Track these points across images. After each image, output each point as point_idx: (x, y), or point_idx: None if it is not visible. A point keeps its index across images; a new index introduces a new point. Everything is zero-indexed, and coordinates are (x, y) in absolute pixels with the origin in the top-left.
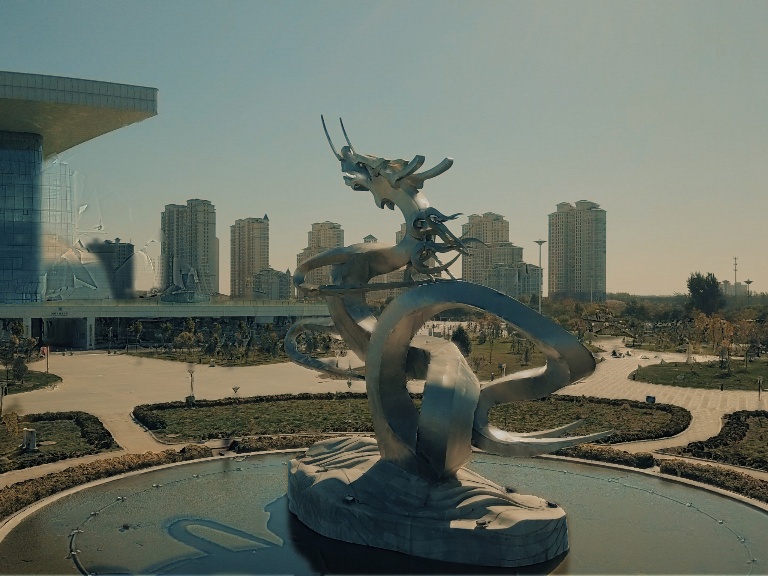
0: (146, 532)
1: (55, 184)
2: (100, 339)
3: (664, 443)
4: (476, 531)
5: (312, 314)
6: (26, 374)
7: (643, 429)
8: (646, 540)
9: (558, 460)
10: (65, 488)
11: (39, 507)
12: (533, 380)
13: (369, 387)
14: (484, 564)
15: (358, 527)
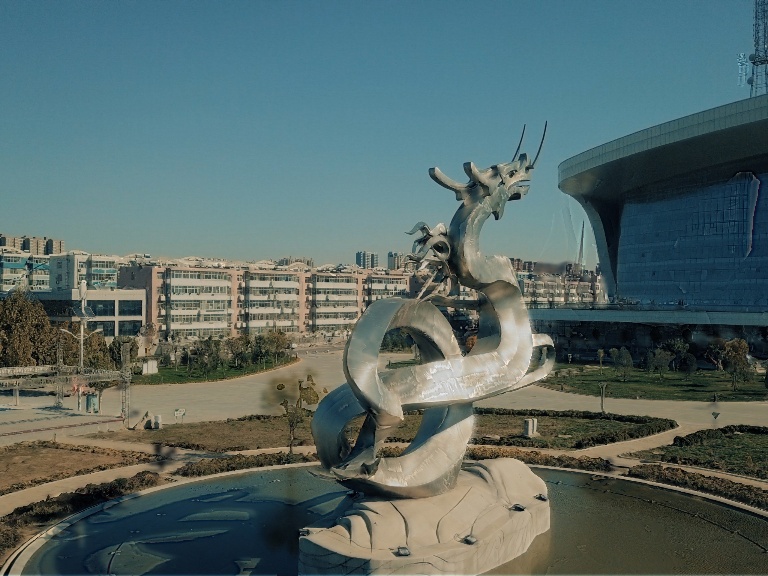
0: None
1: (735, 194)
2: None
3: None
4: None
5: None
6: None
7: None
8: None
9: None
10: None
11: None
12: None
13: None
14: None
15: None
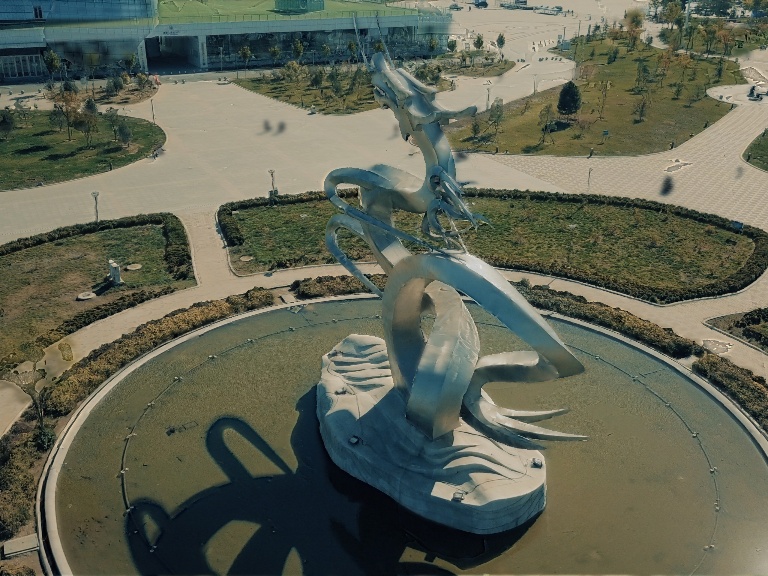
0: (188, 437)
1: None
2: (213, 58)
3: (723, 304)
4: (452, 503)
5: (426, 32)
6: (135, 126)
7: (713, 273)
8: (626, 495)
9: (599, 333)
10: (134, 358)
11: (107, 391)
12: (525, 368)
13: (385, 324)
14: (458, 528)
15: (359, 467)
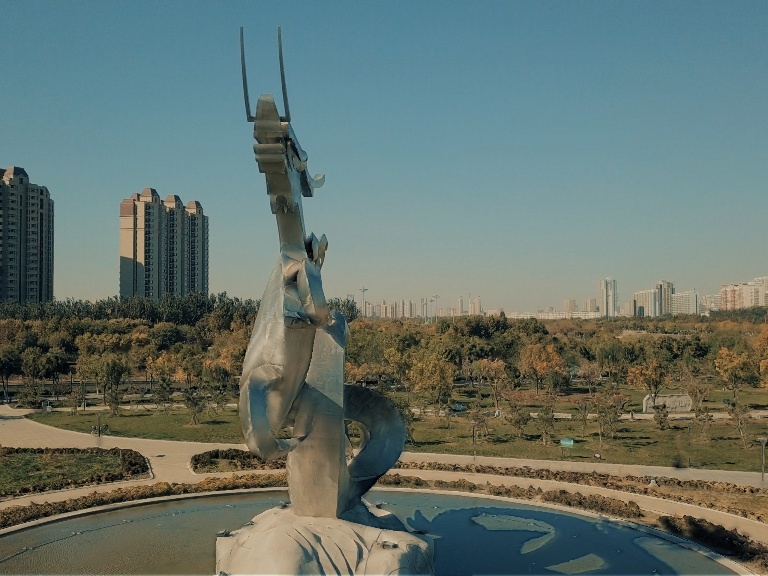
0: None
1: None
2: None
3: None
4: None
5: None
6: None
7: None
8: None
9: None
10: None
11: None
12: None
13: None
14: None
15: None
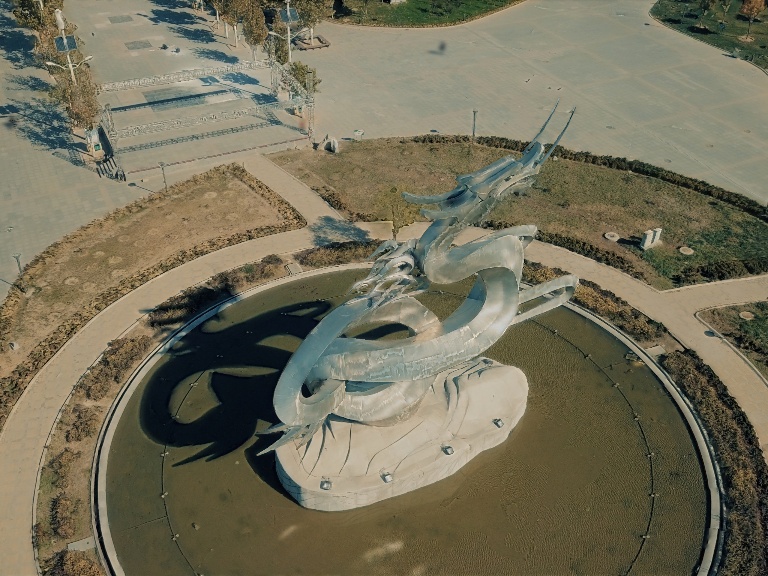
0: None
1: None
2: None
3: None
4: None
5: None
6: None
7: None
8: (319, 573)
9: None
10: None
11: None
12: None
13: None
14: None
15: None
